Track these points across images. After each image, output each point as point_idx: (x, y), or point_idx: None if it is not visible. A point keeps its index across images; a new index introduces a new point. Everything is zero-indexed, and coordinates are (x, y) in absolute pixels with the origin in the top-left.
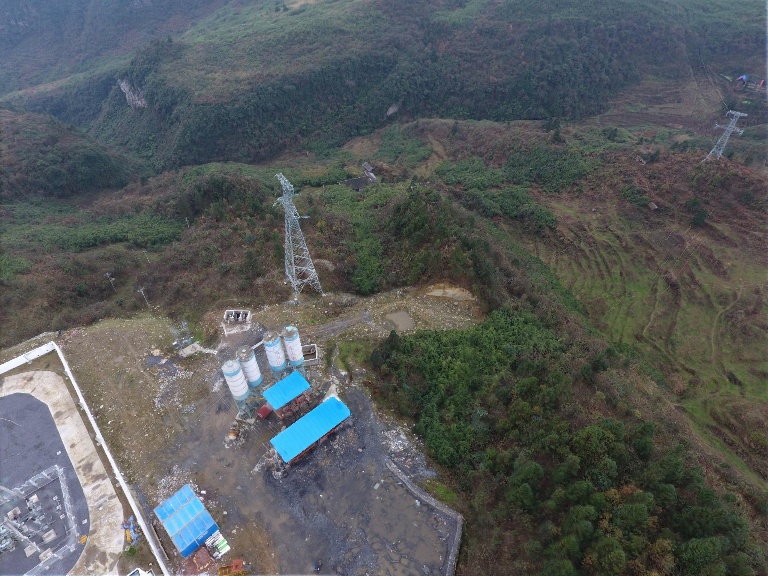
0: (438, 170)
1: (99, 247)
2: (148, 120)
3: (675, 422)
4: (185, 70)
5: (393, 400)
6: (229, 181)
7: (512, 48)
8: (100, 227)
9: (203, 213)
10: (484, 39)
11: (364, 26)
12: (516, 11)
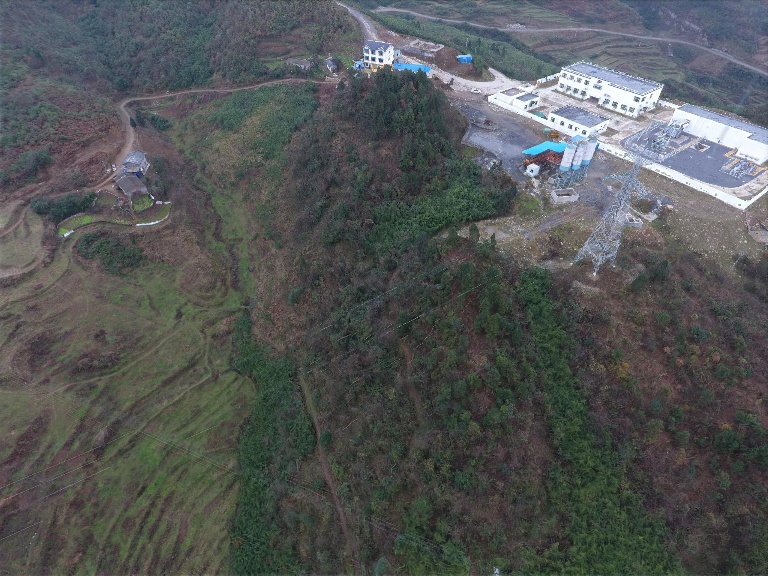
0: None
1: None
2: None
3: (331, 177)
4: None
5: None
6: None
7: None
8: None
9: None
10: None
11: None
12: None
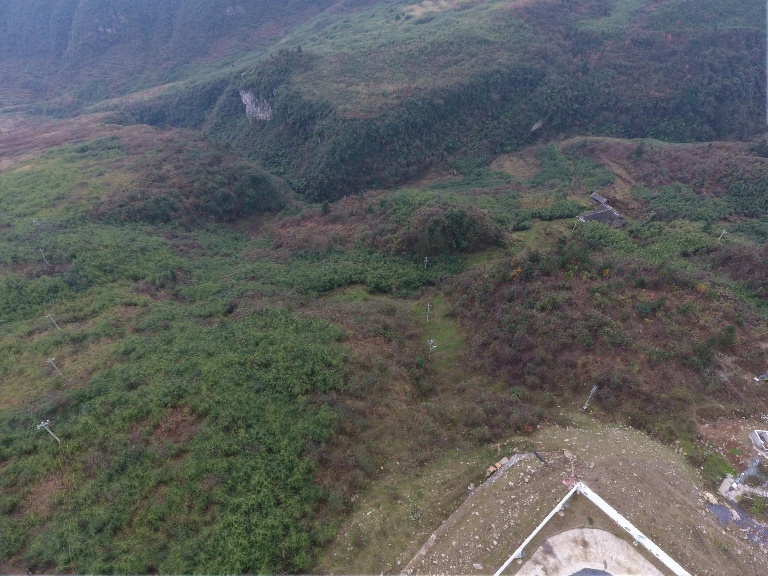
0: None
1: (335, 291)
2: (277, 134)
3: None
4: (320, 82)
5: None
6: (468, 216)
7: (673, 60)
8: (315, 264)
9: (438, 251)
10: (639, 50)
11: (508, 36)
12: (674, 20)
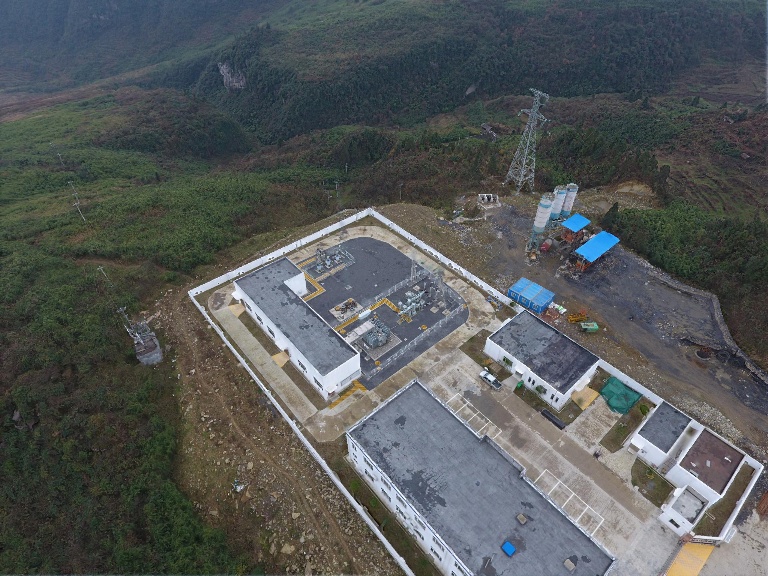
0: None
1: None
2: (249, 99)
3: None
4: (285, 53)
5: (628, 245)
6: (379, 134)
7: (583, 33)
8: None
9: (357, 161)
10: (555, 25)
11: (445, 14)
12: None
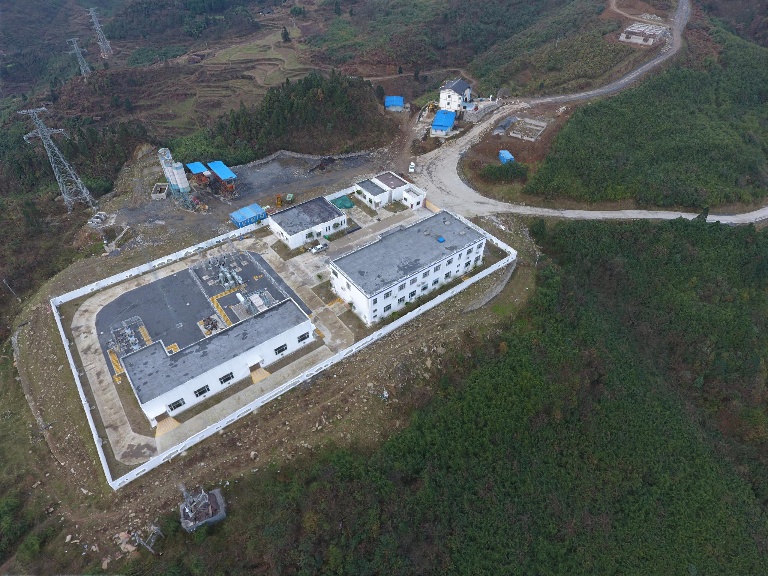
0: None
1: None
2: None
3: None
4: None
5: None
6: None
7: None
8: None
9: None
10: None
11: None
12: None
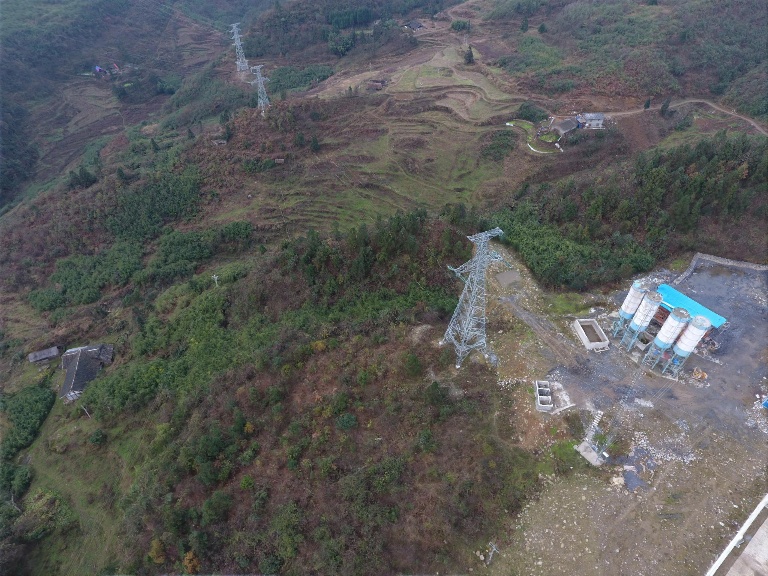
0: (48, 305)
1: None
2: None
3: None
4: None
5: None
6: None
7: None
8: None
9: None
10: None
11: None
12: None
